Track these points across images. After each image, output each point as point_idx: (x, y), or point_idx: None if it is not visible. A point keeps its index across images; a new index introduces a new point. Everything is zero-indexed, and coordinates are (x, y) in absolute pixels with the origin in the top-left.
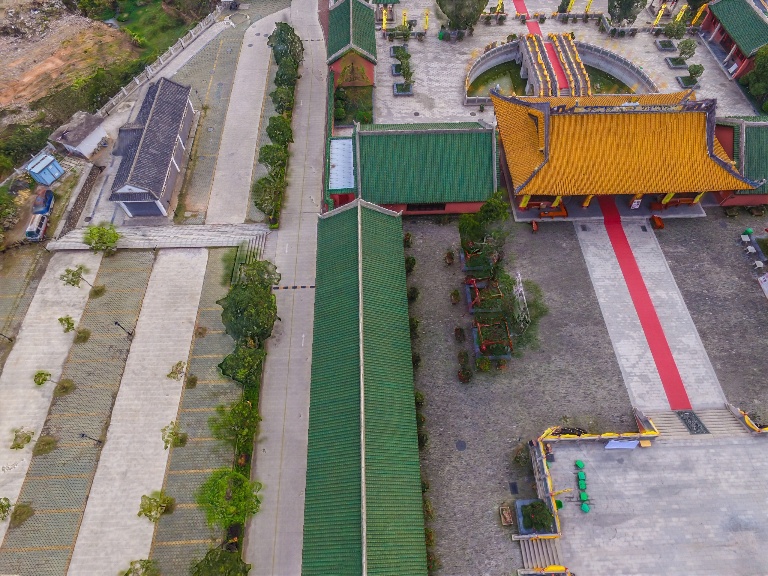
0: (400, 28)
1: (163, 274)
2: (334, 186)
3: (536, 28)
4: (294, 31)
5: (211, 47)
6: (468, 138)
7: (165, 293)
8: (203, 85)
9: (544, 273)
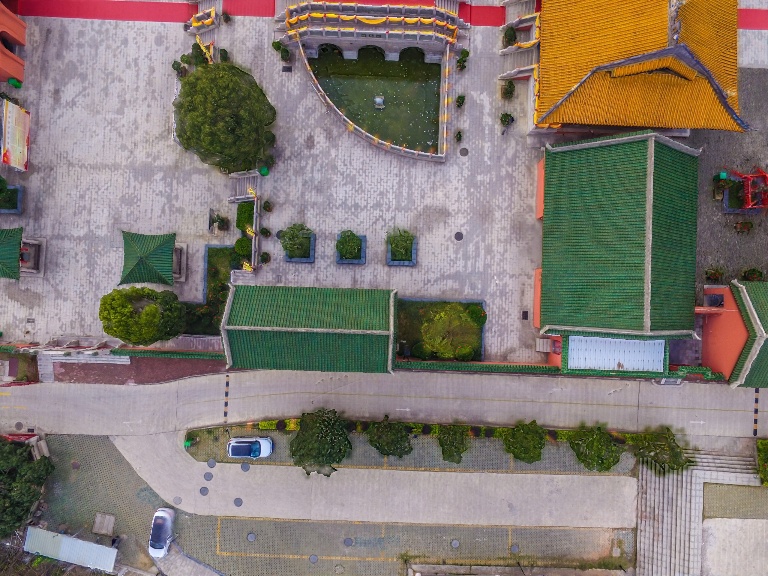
0: (298, 243)
1: (738, 569)
2: (659, 365)
3: (245, 2)
4: (195, 427)
5: (239, 570)
6: (654, 175)
7: (764, 562)
8: (348, 570)
9: (763, 120)
